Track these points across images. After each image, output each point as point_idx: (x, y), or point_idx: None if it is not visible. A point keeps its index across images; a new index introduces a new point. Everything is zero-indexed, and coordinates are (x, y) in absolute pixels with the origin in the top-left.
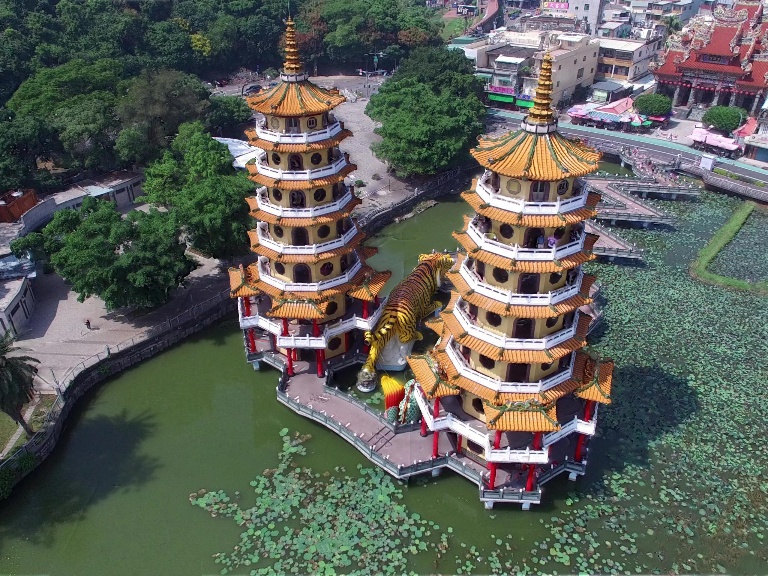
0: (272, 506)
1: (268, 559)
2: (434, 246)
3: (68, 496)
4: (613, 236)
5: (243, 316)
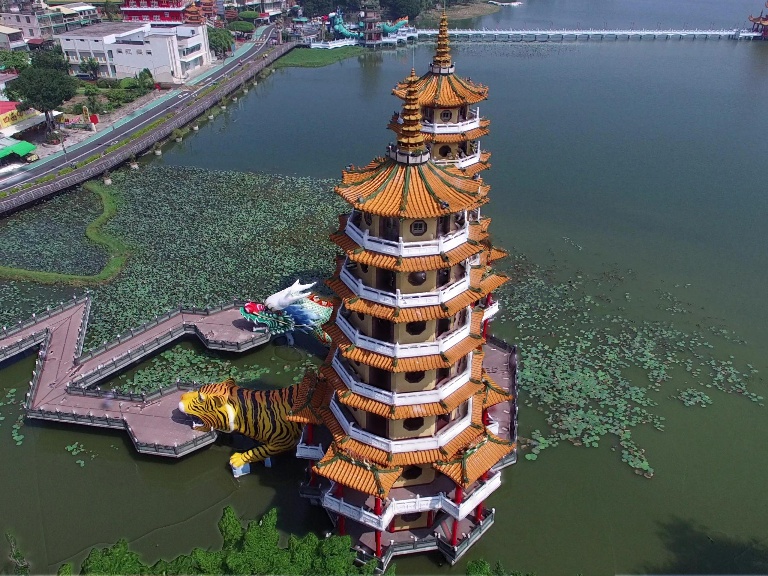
0: (599, 422)
1: (630, 403)
2: (5, 527)
3: (764, 575)
4: (43, 316)
5: (493, 476)
